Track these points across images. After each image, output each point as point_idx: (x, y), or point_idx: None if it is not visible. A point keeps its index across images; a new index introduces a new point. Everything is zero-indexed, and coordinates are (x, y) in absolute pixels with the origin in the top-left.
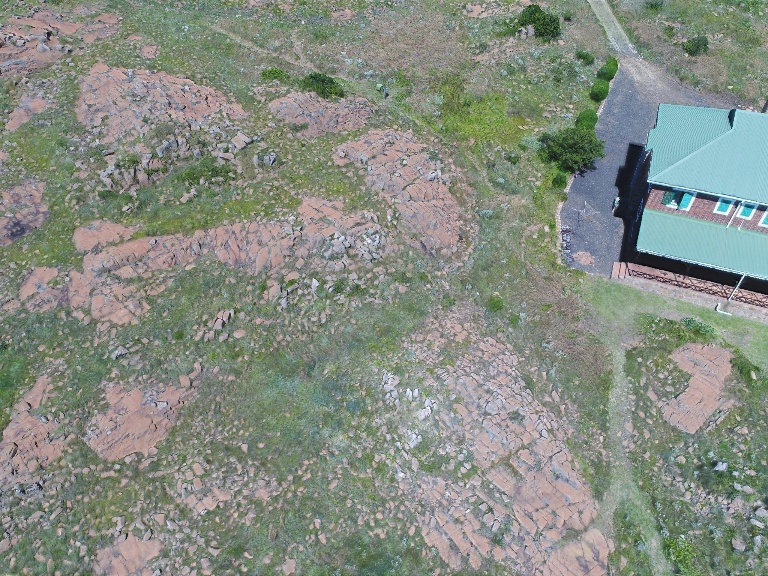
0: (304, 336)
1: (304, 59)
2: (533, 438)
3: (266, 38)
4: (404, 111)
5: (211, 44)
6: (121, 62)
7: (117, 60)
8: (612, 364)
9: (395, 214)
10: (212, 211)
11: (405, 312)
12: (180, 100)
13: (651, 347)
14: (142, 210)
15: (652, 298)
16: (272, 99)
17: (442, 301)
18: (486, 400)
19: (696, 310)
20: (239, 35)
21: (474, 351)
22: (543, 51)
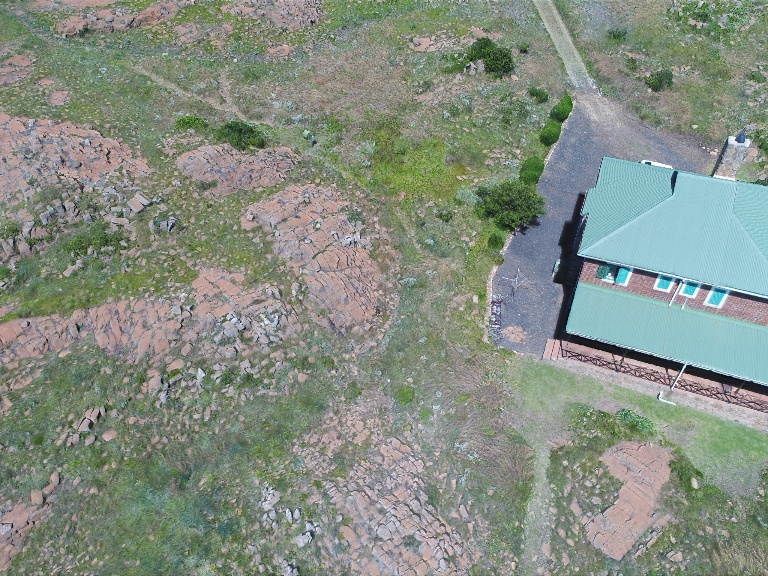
0: (184, 437)
1: (230, 102)
2: (430, 569)
3: (191, 79)
4: (330, 161)
5: (128, 88)
6: (24, 111)
7: (20, 109)
8: (533, 469)
9: (301, 288)
10: (97, 286)
11: (301, 406)
12: (76, 157)
13: (580, 447)
14: (19, 285)
15: (587, 383)
16: (182, 152)
17: (345, 392)
18: (377, 522)
19: (636, 398)
20: (162, 76)
21: (373, 456)
22: (493, 88)
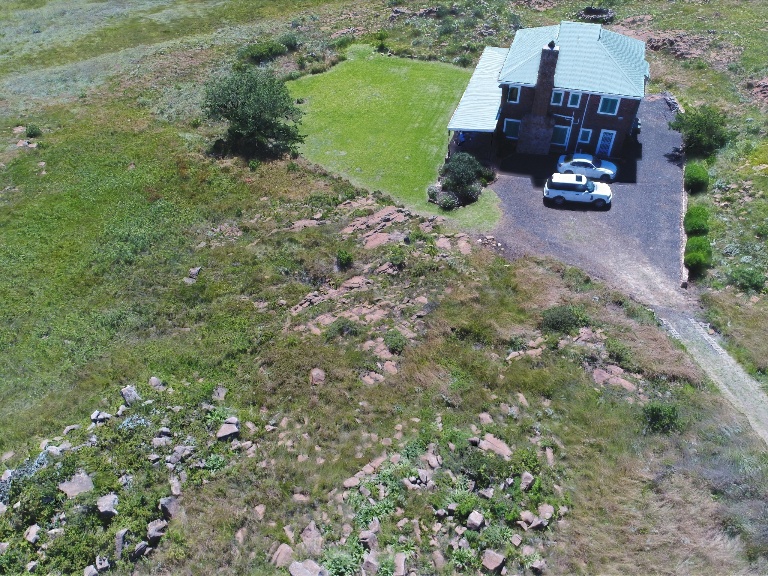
0: None
1: None
2: None
3: None
4: None
5: None
6: None
7: None
8: None
9: None
10: None
11: None
12: None
13: None
14: None
15: None
16: None
17: None
18: None
19: None
20: None
21: None
22: None
